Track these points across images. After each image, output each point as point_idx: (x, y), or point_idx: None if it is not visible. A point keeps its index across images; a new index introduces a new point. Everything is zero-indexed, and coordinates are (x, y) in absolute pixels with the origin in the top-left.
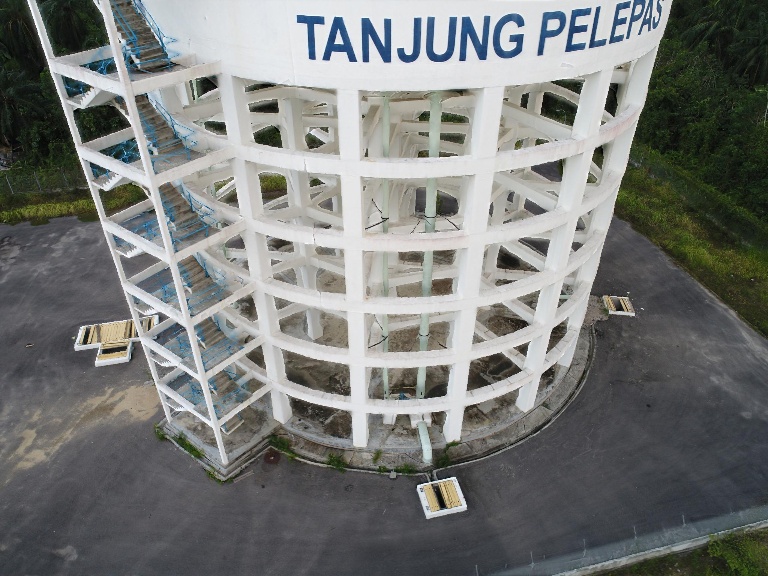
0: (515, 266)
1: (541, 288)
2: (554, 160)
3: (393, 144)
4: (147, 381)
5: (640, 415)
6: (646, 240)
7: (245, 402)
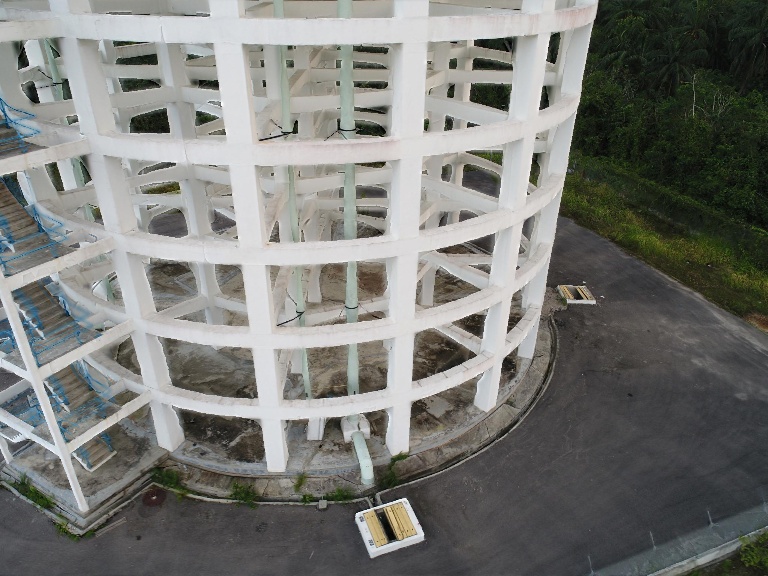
0: None
1: (497, 231)
2: (503, 36)
3: None
4: None
5: (623, 406)
6: (593, 233)
7: (110, 418)
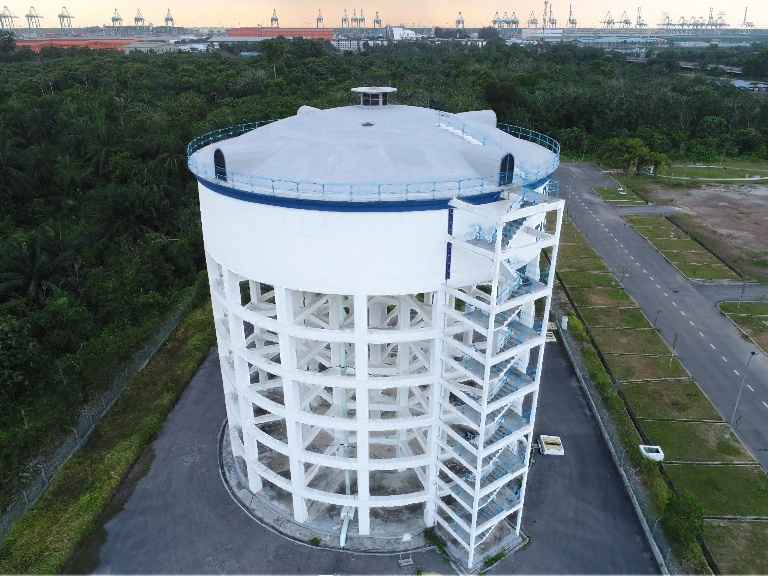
0: None
1: None
2: None
3: (379, 309)
4: None
5: None
6: None
7: None
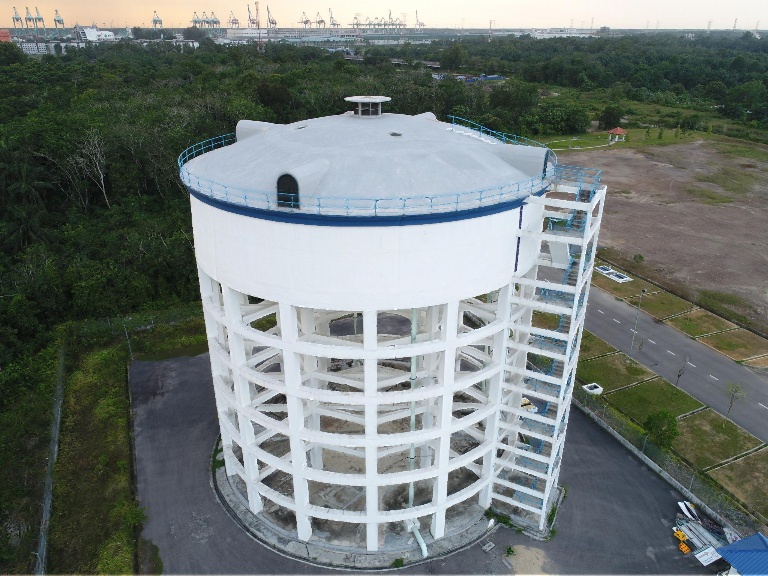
0: None
1: None
2: None
3: None
4: (508, 567)
5: None
6: None
7: None
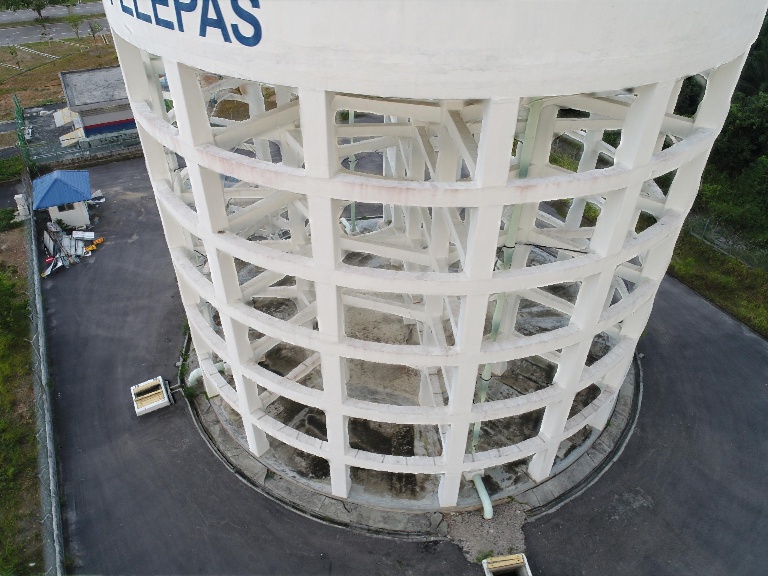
0: (537, 430)
1: None
2: (159, 141)
3: None
4: None
5: None
6: None
7: None
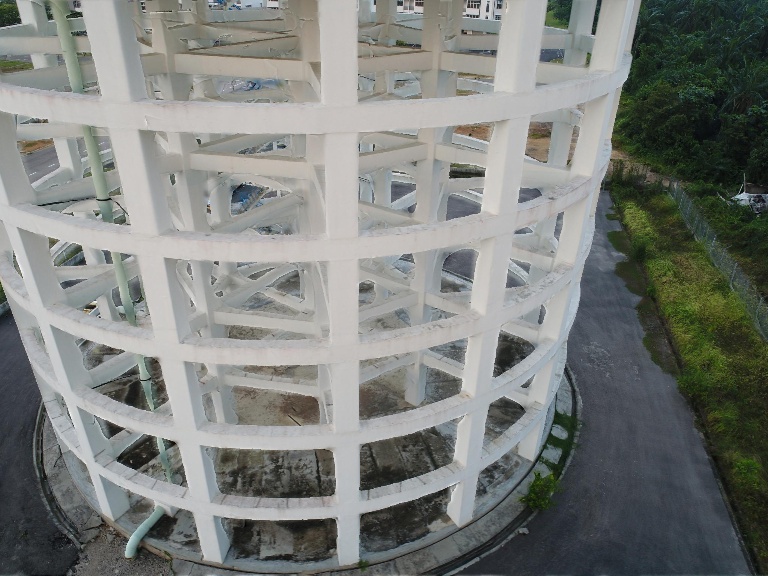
0: None
1: None
2: None
3: None
4: None
5: None
6: None
7: None
